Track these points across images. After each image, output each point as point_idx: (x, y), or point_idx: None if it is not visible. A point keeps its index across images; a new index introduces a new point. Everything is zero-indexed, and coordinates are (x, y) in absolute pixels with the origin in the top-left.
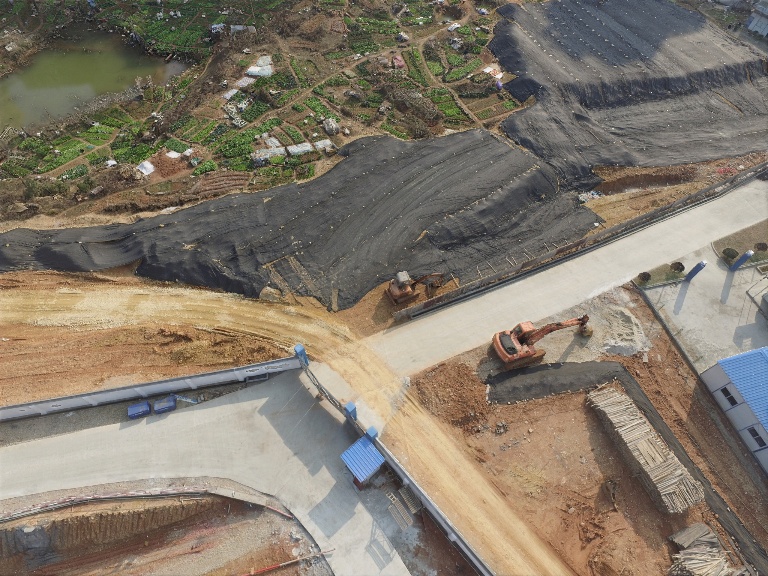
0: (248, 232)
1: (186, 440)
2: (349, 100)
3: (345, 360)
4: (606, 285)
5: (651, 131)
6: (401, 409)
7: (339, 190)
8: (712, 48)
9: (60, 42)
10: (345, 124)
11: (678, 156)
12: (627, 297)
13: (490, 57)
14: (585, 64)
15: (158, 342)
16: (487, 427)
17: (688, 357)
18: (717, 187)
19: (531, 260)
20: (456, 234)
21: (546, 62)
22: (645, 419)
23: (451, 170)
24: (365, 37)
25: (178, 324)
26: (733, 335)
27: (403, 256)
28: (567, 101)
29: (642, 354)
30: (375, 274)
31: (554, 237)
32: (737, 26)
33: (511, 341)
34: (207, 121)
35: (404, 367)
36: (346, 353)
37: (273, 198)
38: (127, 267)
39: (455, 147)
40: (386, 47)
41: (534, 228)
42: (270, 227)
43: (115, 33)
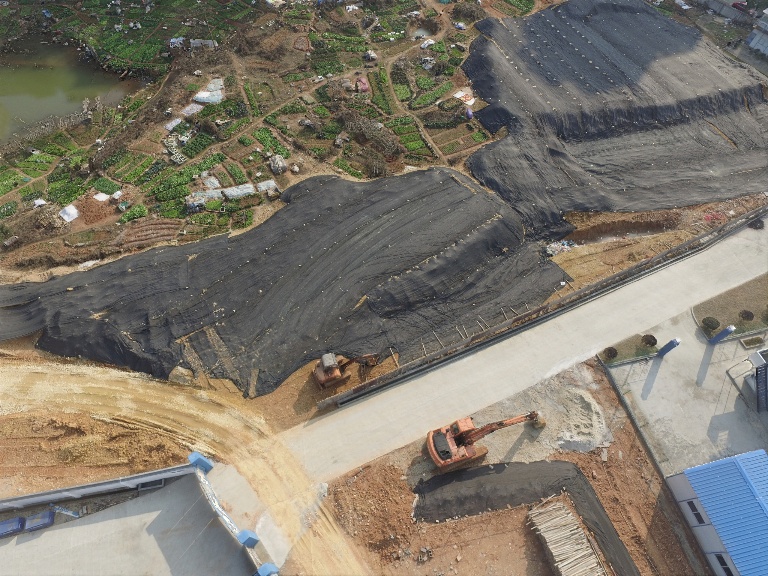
0: (165, 297)
1: (58, 566)
2: (303, 130)
3: (255, 461)
4: (567, 361)
5: (633, 168)
6: (312, 527)
7: (274, 245)
8: (707, 71)
9: (11, 56)
10: (295, 160)
11: (661, 199)
12: (590, 377)
13: (463, 79)
14: (565, 90)
15: (46, 436)
16: (409, 553)
17: (654, 455)
18: (703, 237)
19: (482, 333)
20: (401, 299)
21: (522, 88)
22: (594, 544)
23: (402, 220)
24: (330, 55)
25: (73, 412)
26: (708, 427)
27: (337, 328)
28: (542, 134)
29: (601, 450)
30: (303, 350)
31: (513, 300)
32: (737, 43)
33: (446, 442)
34: (143, 157)
35: (323, 470)
36: (258, 452)
37: (199, 255)
38: (28, 338)
39: (410, 192)
40: (351, 67)
41: (492, 289)
42: (191, 291)
43: (70, 46)
